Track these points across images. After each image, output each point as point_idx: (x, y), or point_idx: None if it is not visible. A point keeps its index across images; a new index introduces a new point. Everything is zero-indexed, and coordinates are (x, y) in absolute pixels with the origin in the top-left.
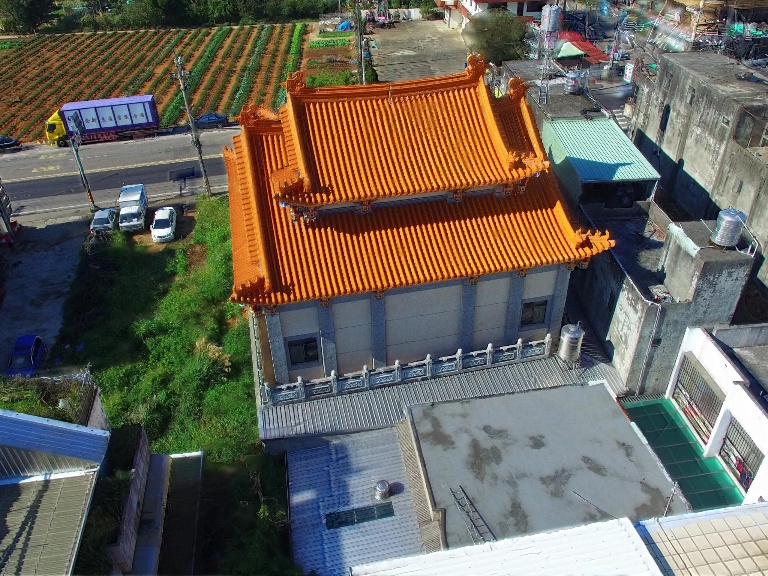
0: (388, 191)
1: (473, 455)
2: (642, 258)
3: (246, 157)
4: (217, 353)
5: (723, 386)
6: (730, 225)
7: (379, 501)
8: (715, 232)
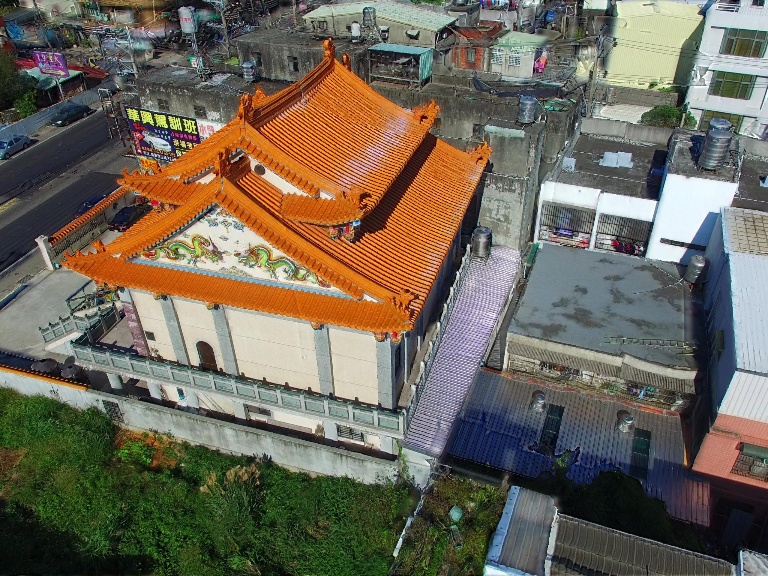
0: (395, 173)
1: (578, 321)
2: None
3: (254, 208)
4: None
5: (584, 204)
6: (533, 106)
7: (545, 411)
8: (523, 116)
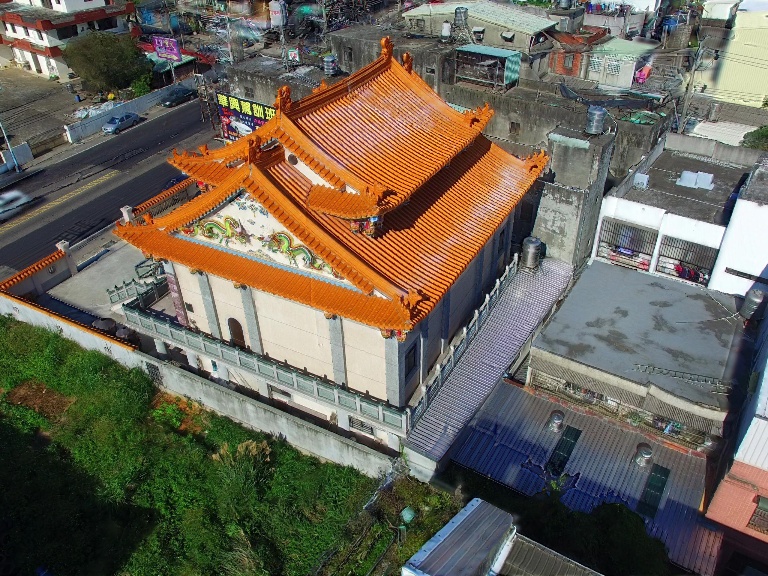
0: (428, 173)
1: (609, 344)
2: None
3: (277, 195)
4: (255, 447)
5: (647, 223)
6: (602, 117)
7: (561, 432)
8: (590, 126)
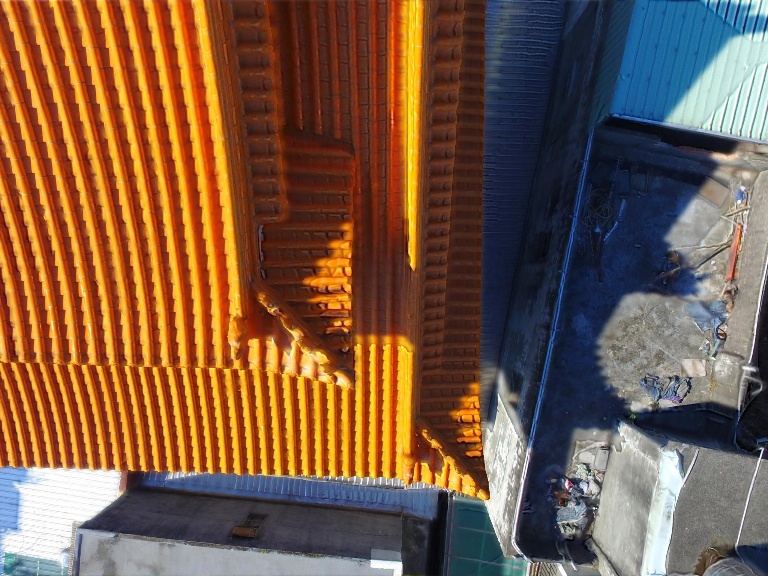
0: None
1: None
2: (628, 343)
3: None
4: None
5: None
6: None
7: None
8: None
